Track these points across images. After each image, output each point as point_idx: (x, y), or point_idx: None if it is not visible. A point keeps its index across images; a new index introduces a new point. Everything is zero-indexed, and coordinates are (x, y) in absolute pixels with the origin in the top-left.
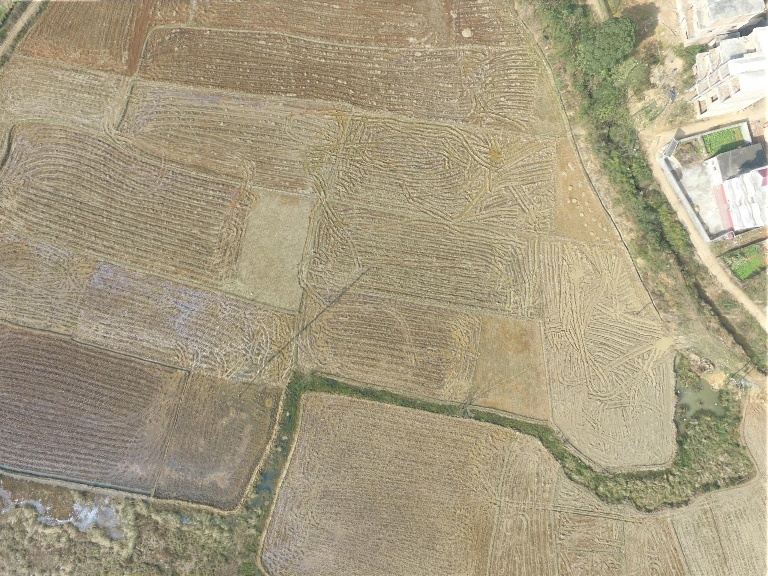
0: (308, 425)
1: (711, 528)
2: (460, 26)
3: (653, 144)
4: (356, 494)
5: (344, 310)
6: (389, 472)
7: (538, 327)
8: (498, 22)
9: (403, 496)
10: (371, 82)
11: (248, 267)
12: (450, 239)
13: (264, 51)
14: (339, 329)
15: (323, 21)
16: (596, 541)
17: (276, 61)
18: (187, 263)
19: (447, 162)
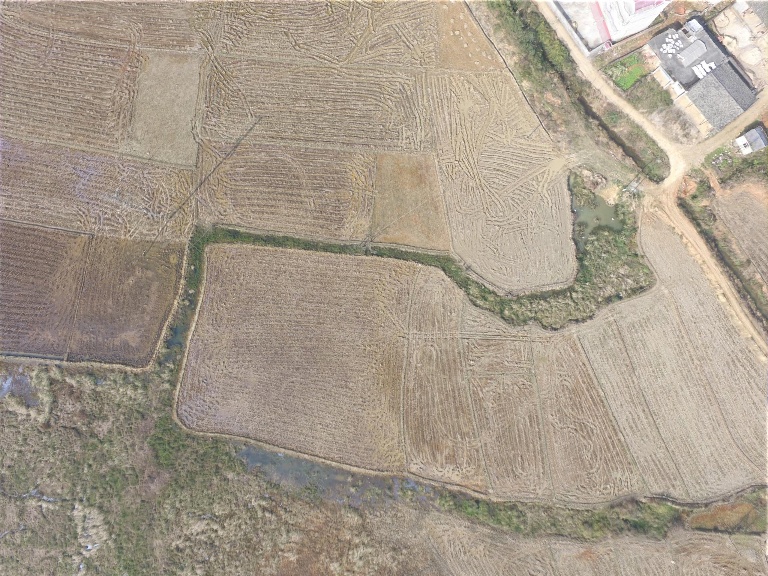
0: (213, 277)
1: (617, 340)
2: None
3: None
4: (266, 340)
5: (240, 161)
6: (297, 316)
7: (432, 160)
8: None
9: (312, 338)
10: None
11: (143, 127)
12: (339, 82)
13: None
14: (237, 180)
15: None
16: (506, 364)
17: None
18: (82, 129)
19: (329, 7)
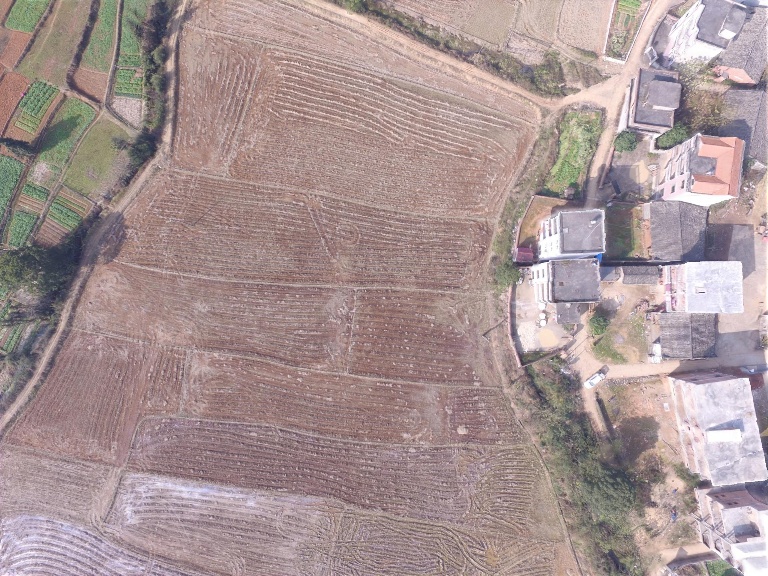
0: None
1: None
2: (455, 423)
3: (654, 561)
4: None
5: None
6: None
7: None
8: (494, 419)
9: None
10: (364, 479)
11: None
12: None
13: (255, 443)
14: None
15: (315, 414)
16: None
17: (267, 455)
18: None
19: (442, 564)
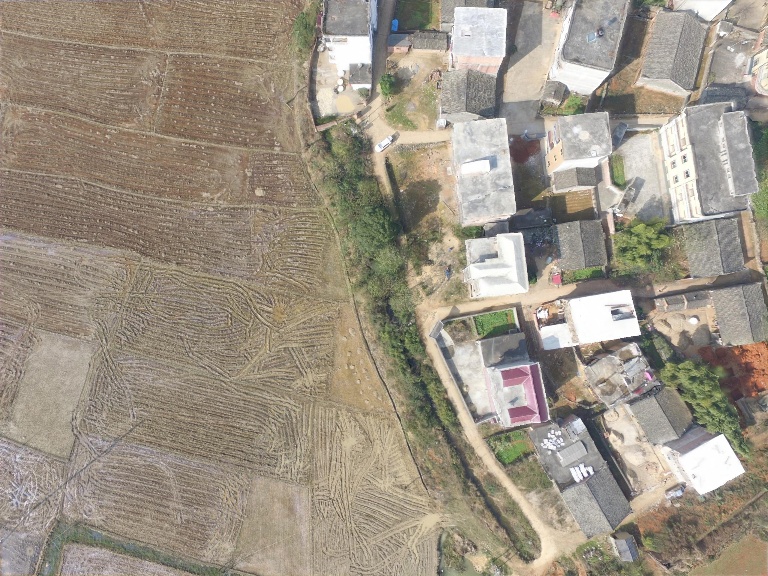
0: None
1: None
2: (253, 185)
3: (429, 319)
4: None
5: (114, 461)
6: None
7: (306, 493)
8: (291, 183)
9: None
10: (162, 233)
11: (23, 410)
12: (226, 396)
13: (60, 195)
14: (108, 480)
15: (120, 170)
16: None
17: (70, 206)
18: None
19: (230, 319)
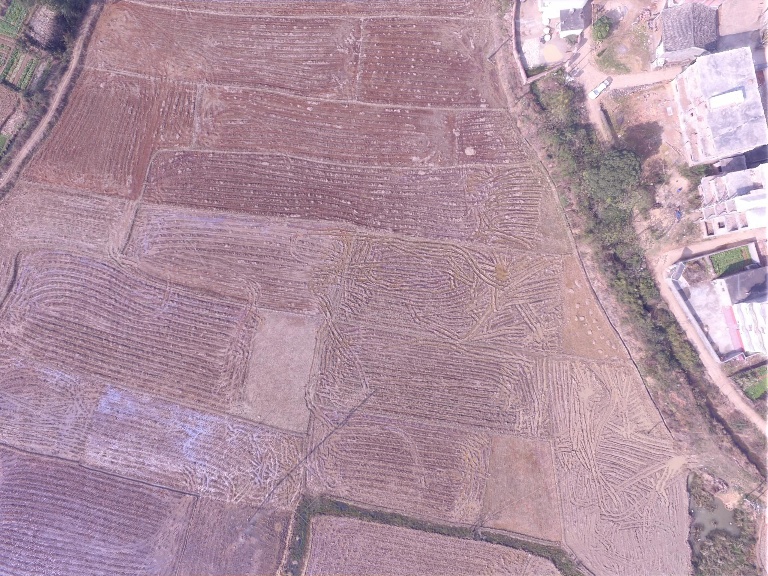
0: (318, 549)
1: None
2: (463, 144)
3: (660, 263)
4: None
5: (352, 432)
6: None
7: (548, 447)
8: (501, 140)
9: None
10: (375, 202)
11: (255, 389)
12: (457, 359)
13: (267, 172)
14: (347, 451)
15: (326, 142)
16: None
17: (279, 182)
18: (194, 386)
19: (453, 281)
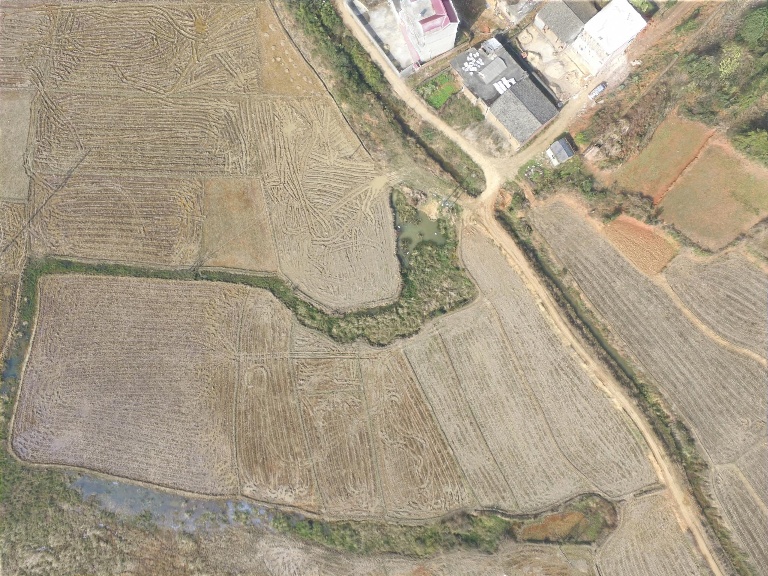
0: (47, 307)
1: (443, 353)
2: None
3: None
4: (99, 368)
5: (71, 192)
6: (129, 343)
7: (258, 183)
8: None
9: (145, 364)
10: None
11: None
12: (165, 111)
13: None
14: (68, 211)
15: None
16: (335, 382)
17: None
18: None
19: (155, 39)
